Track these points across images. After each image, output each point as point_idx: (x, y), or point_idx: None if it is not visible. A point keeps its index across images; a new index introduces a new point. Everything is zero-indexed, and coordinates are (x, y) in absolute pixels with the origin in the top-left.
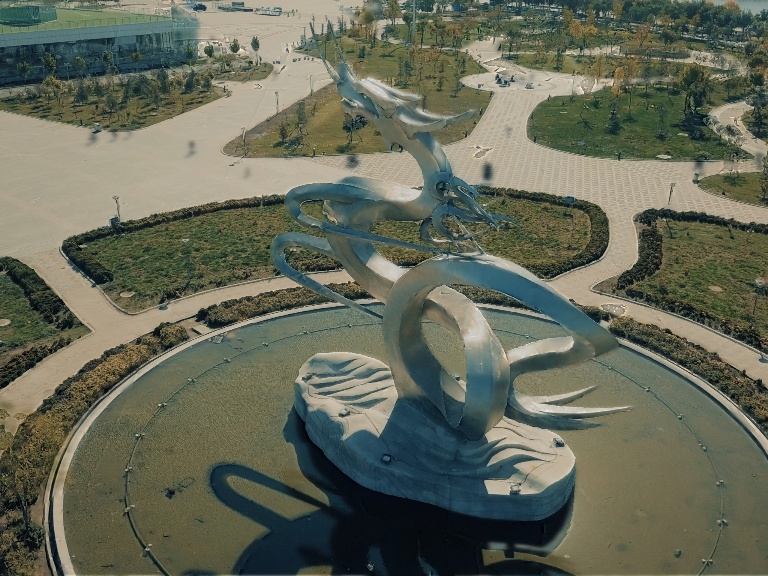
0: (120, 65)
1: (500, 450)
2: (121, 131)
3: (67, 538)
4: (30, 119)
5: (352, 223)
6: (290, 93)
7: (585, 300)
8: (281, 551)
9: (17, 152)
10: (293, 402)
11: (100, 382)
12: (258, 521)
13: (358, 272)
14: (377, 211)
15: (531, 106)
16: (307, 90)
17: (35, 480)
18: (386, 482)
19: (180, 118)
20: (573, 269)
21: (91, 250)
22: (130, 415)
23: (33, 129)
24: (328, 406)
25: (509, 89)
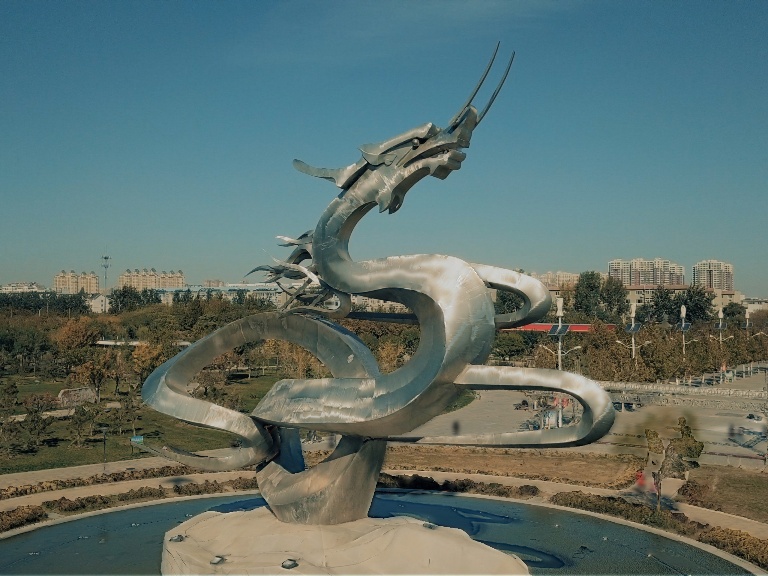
0: None
1: None
2: None
3: None
4: None
5: None
6: None
7: None
8: None
9: None
10: None
11: None
12: (483, 541)
13: None
14: None
15: None
16: None
17: None
18: None
19: None
20: None
21: None
22: None
23: None
24: None
25: None
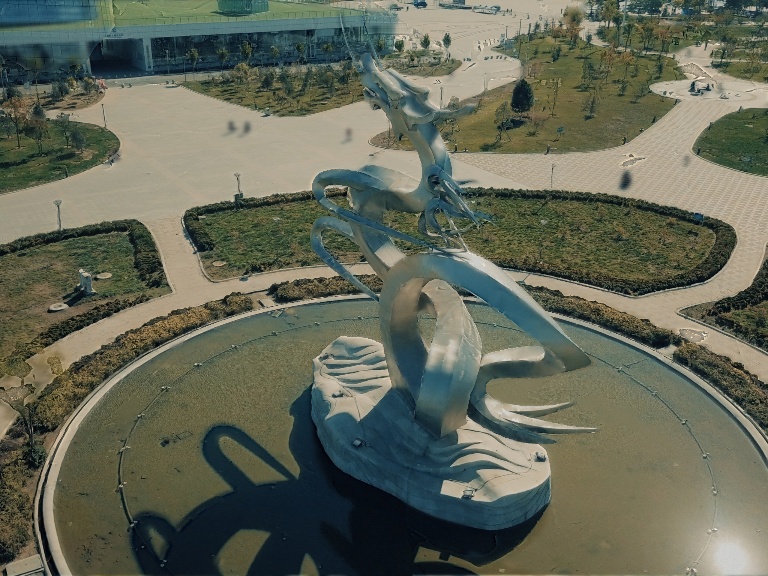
0: (317, 56)
1: (468, 453)
2: (287, 116)
3: (63, 464)
4: (215, 101)
5: (364, 210)
6: (465, 90)
7: (664, 322)
8: (234, 510)
9: (189, 129)
10: None
11: (153, 336)
12: (227, 480)
13: (372, 260)
14: (384, 200)
15: (715, 117)
16: (483, 88)
17: (61, 411)
18: (354, 466)
19: (347, 108)
20: (668, 289)
21: (208, 221)
22: (167, 369)
23: (213, 110)
24: (326, 386)
25: (700, 98)
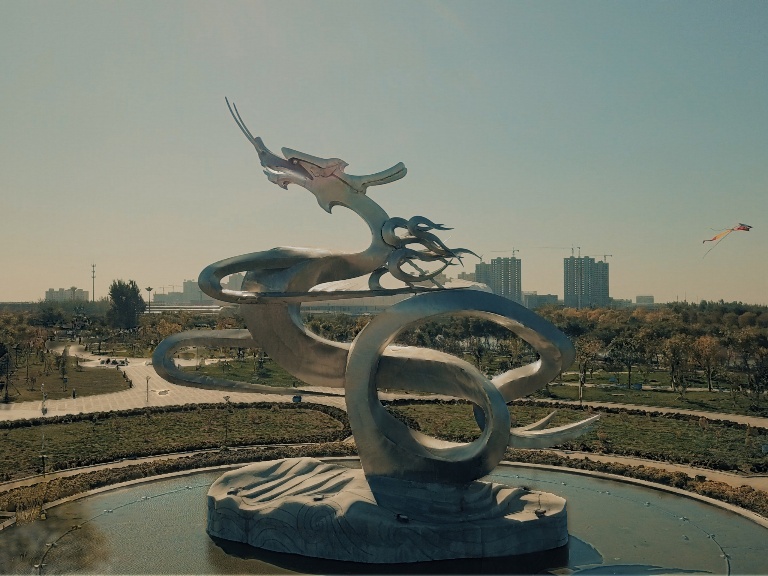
0: None
1: (498, 490)
2: None
3: None
4: None
5: (288, 290)
6: None
7: None
8: None
9: None
10: (207, 537)
11: None
12: None
13: (289, 350)
14: (319, 272)
15: None
16: None
17: None
18: (409, 546)
19: None
20: None
21: None
22: None
23: None
24: (294, 497)
25: (130, 366)
